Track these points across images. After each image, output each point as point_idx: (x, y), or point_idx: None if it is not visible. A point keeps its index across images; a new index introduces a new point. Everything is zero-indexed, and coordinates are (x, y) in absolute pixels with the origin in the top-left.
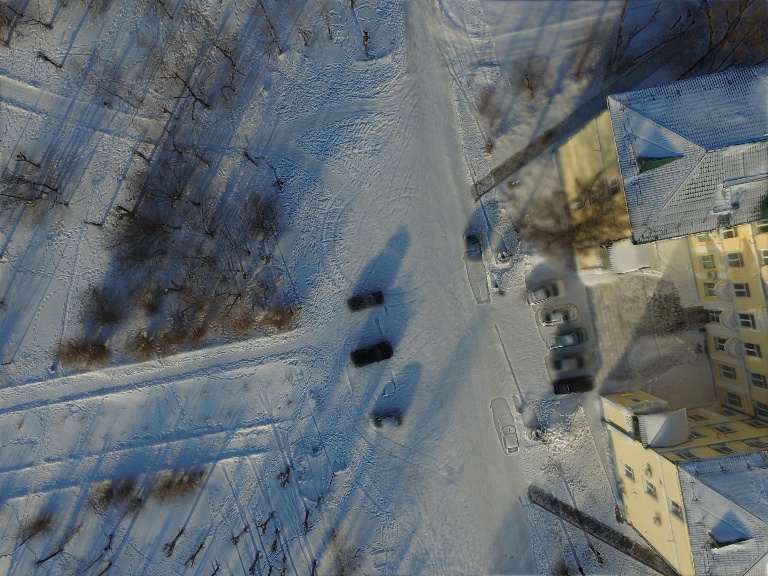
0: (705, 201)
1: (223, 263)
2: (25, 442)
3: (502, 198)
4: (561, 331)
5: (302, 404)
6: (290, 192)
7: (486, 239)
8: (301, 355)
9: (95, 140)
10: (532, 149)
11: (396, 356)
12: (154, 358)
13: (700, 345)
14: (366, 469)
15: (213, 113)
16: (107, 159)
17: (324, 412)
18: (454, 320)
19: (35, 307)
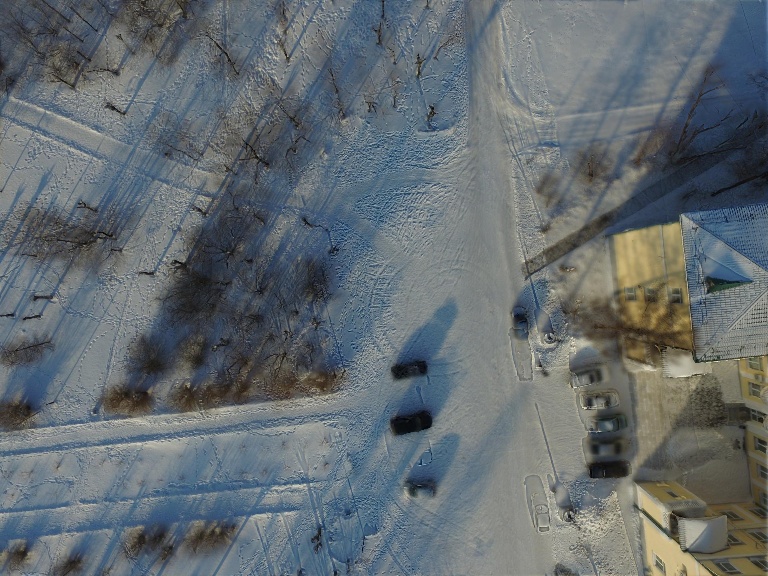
0: None
1: (271, 320)
2: (62, 481)
3: (552, 278)
4: (601, 415)
5: (338, 466)
6: (342, 255)
7: (533, 317)
8: (341, 418)
9: (153, 189)
10: (586, 232)
11: (435, 426)
12: (196, 409)
13: (739, 441)
14: (396, 535)
15: (272, 171)
16: (164, 209)
17: (359, 475)
18: (495, 395)
19: (82, 349)
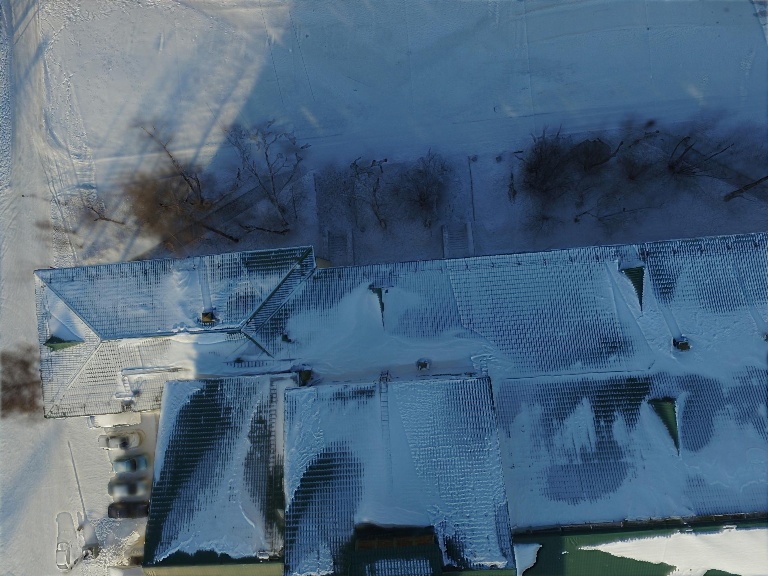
0: (107, 386)
1: None
2: None
3: None
4: (125, 455)
5: None
6: None
7: None
8: None
9: None
10: None
11: None
12: None
13: None
14: None
15: None
16: None
17: None
18: (30, 432)
19: None
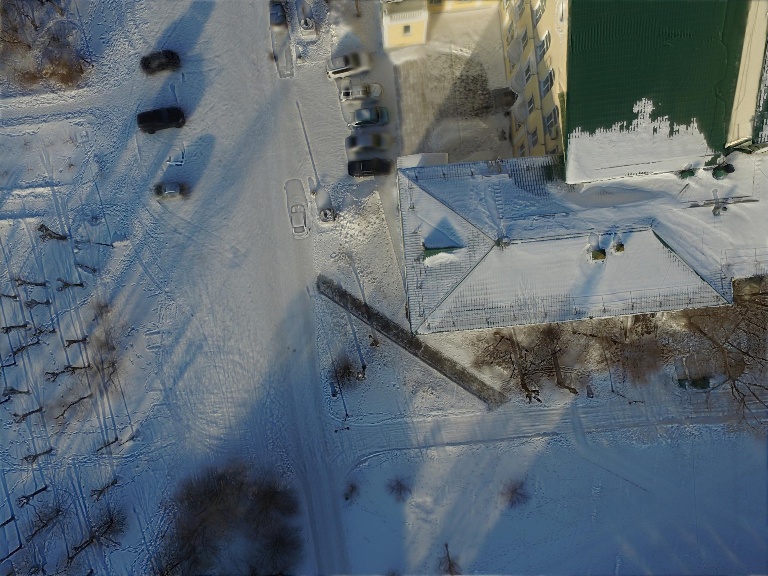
0: None
1: (15, 12)
2: None
3: None
4: None
5: (85, 168)
6: None
7: (294, 9)
8: (88, 116)
9: None
10: None
11: (189, 126)
12: None
13: (504, 132)
14: (148, 244)
15: None
16: None
17: (108, 179)
18: (254, 93)
19: None
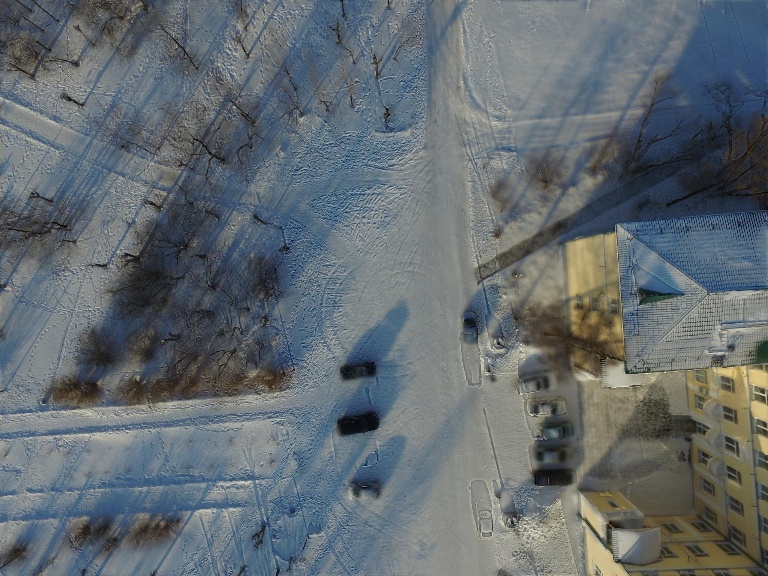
0: (701, 340)
1: (222, 316)
2: (10, 470)
3: (504, 284)
4: (548, 422)
5: (284, 464)
6: (295, 254)
7: (484, 322)
8: (289, 416)
9: (109, 181)
10: (540, 238)
11: (382, 427)
12: (144, 403)
13: (684, 454)
14: (340, 535)
15: (228, 167)
16: (119, 201)
17: (305, 474)
18: (443, 398)
19: (33, 338)
